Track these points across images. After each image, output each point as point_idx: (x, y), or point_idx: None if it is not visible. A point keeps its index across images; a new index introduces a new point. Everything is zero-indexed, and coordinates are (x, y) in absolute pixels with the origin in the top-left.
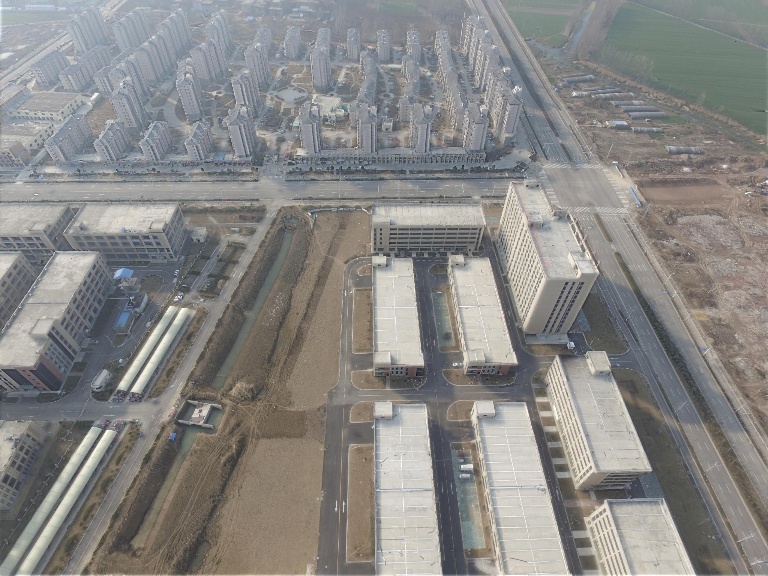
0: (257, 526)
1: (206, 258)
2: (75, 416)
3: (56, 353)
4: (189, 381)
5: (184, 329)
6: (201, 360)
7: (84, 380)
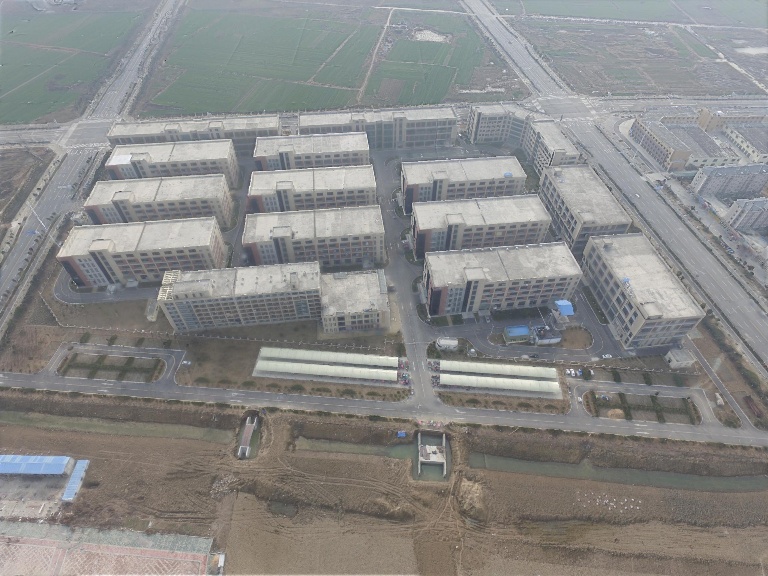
0: (311, 567)
1: (647, 380)
2: (409, 339)
3: (458, 296)
4: (467, 426)
5: (532, 395)
6: (497, 430)
7: (445, 330)
